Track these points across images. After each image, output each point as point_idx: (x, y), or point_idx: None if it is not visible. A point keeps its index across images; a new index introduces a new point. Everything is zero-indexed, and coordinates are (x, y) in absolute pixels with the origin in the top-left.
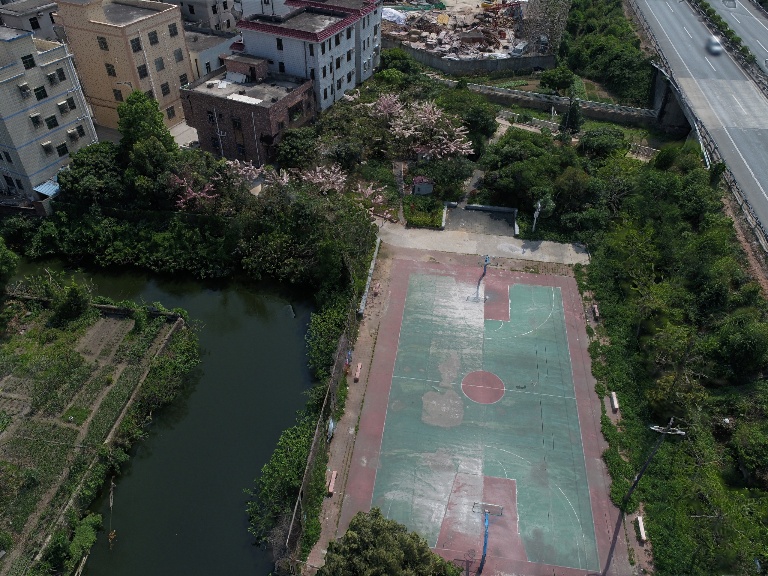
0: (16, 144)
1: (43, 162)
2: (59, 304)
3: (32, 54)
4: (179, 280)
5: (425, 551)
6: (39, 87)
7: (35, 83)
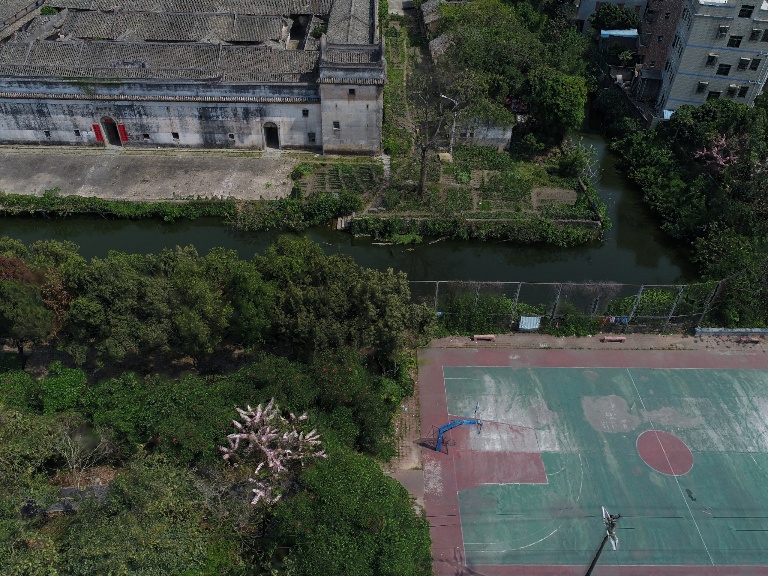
0: (681, 69)
1: (689, 96)
2: (563, 160)
3: (755, 6)
4: (650, 218)
5: (391, 318)
6: (738, 36)
7: (737, 31)
